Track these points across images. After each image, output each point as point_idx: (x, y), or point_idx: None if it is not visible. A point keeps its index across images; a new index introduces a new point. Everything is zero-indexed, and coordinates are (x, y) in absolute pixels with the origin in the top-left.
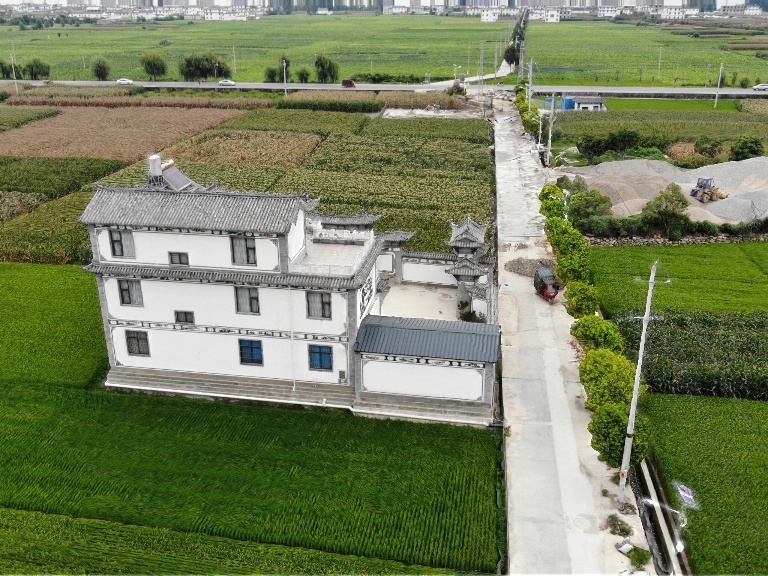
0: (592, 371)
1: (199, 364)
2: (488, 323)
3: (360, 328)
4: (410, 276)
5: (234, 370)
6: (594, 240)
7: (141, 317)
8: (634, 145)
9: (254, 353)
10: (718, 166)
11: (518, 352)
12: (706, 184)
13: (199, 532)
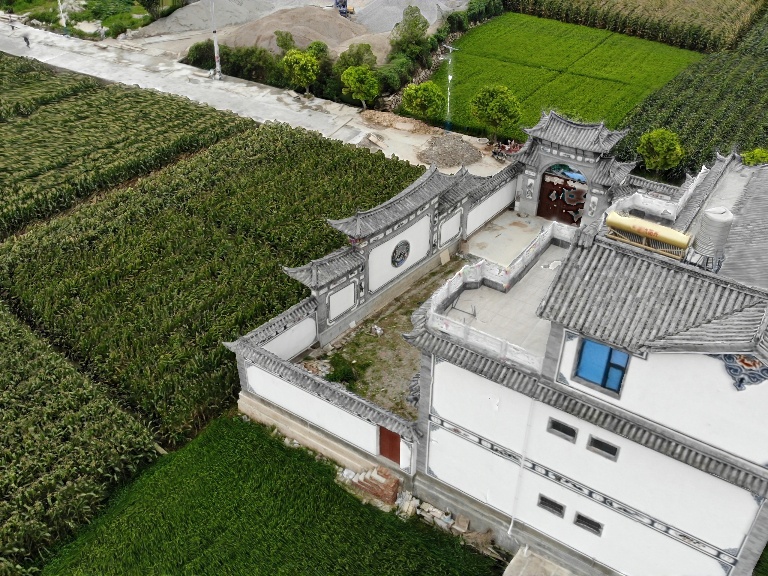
0: None
1: None
2: None
3: None
4: (472, 226)
5: None
6: (395, 98)
7: None
8: None
9: None
10: None
11: None
12: (346, 1)
13: None
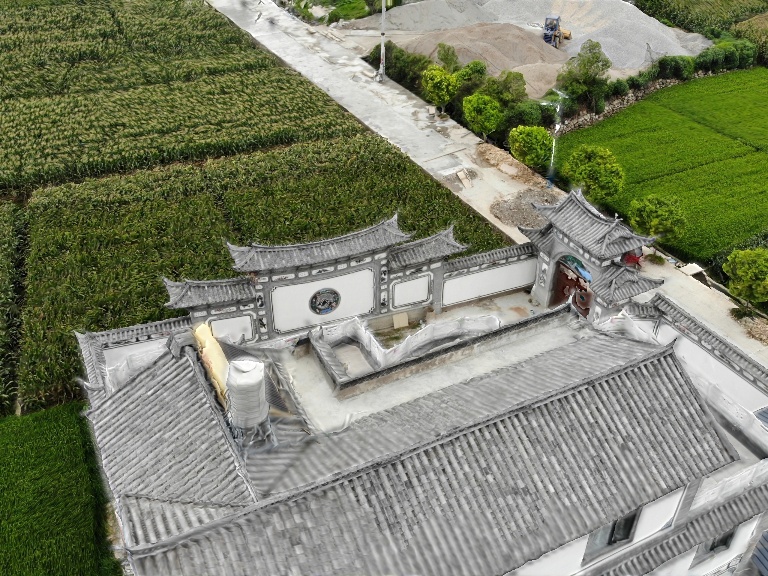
0: None
1: None
2: (767, 382)
3: None
4: (454, 297)
5: None
6: None
7: None
8: None
9: None
10: None
11: None
12: (557, 25)
13: None
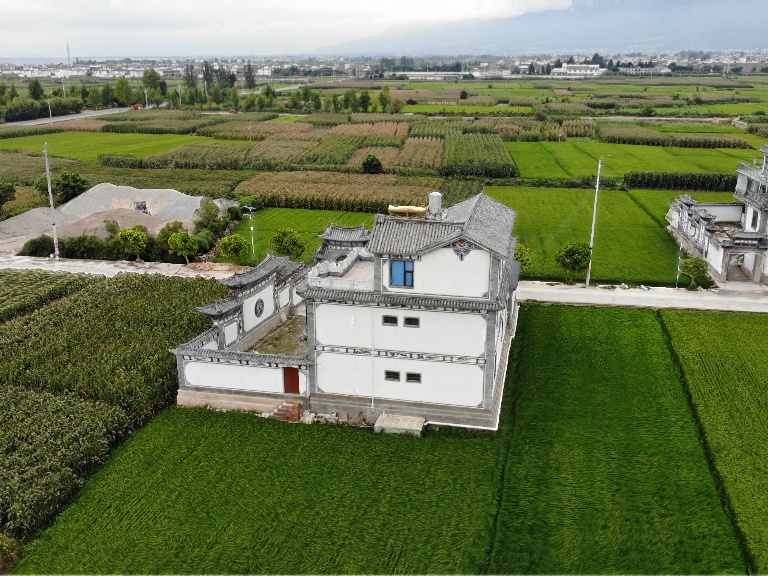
0: (516, 252)
1: None
2: None
3: None
4: None
5: None
6: (207, 256)
7: None
8: (14, 199)
9: None
10: (81, 199)
11: None
12: None
13: None
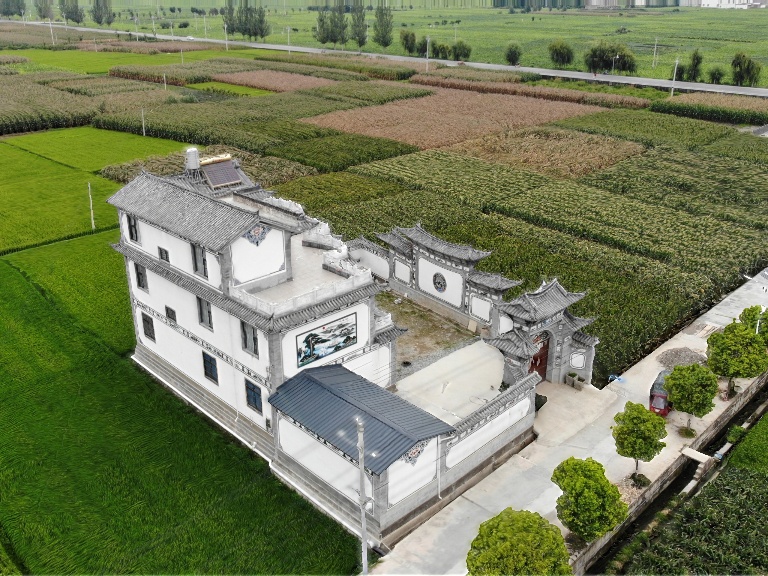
0: (483, 537)
1: (182, 364)
2: None
3: (295, 377)
4: None
5: (202, 380)
6: None
7: (149, 303)
8: None
9: (212, 370)
10: None
11: (524, 471)
12: None
13: (3, 527)
